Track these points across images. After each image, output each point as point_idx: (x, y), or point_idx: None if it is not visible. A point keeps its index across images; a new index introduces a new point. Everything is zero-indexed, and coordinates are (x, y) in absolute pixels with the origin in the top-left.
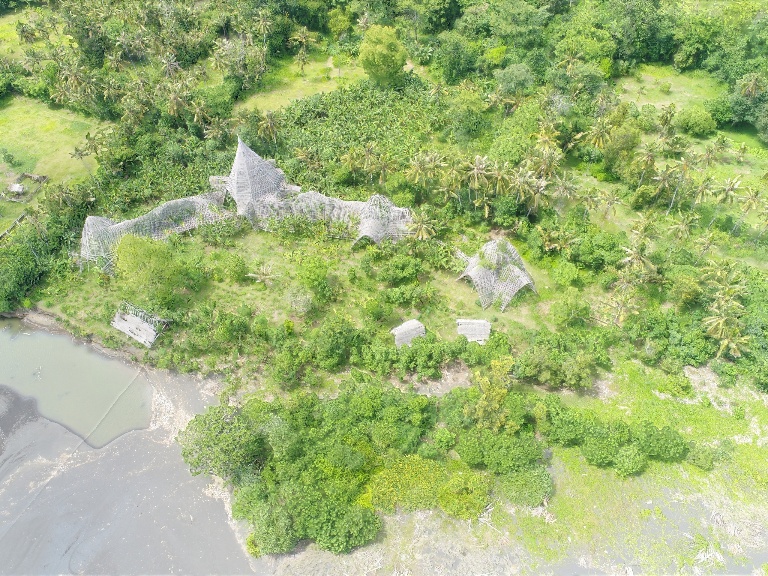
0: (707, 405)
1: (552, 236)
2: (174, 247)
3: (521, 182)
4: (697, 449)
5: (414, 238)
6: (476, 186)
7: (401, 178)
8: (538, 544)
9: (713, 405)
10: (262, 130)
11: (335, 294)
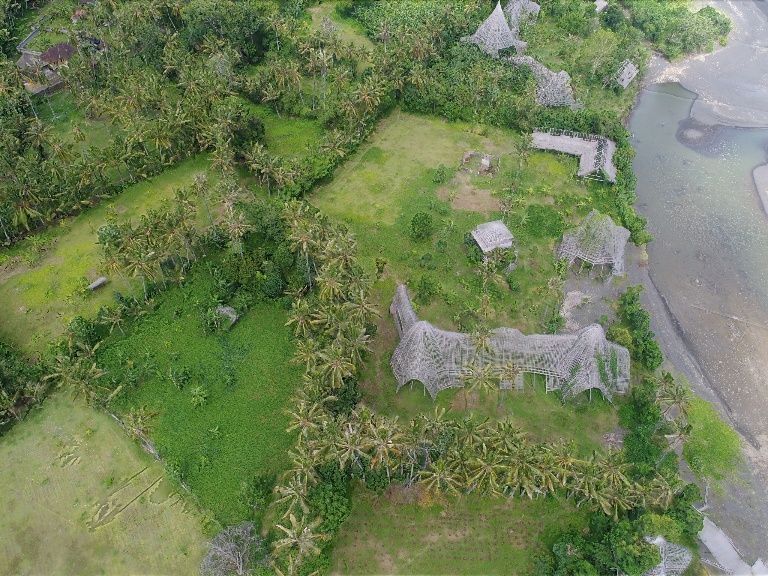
0: None
1: None
2: None
3: None
4: None
5: None
6: None
7: None
8: None
9: None
10: None
11: None
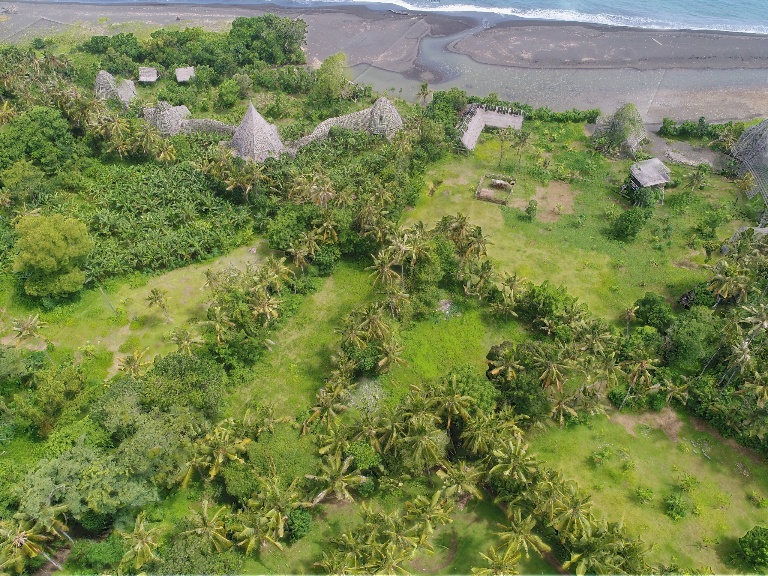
0: None
1: None
2: None
3: None
4: None
5: None
6: None
7: None
8: None
9: None
10: None
11: None
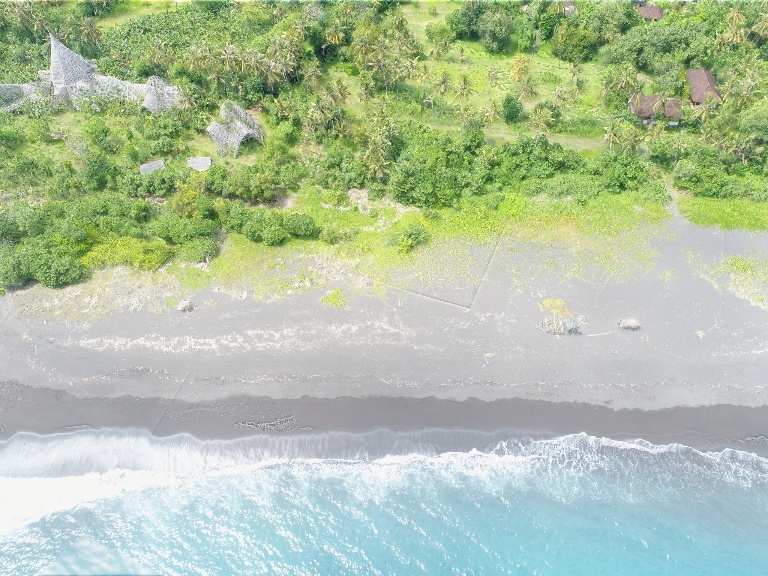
0: (353, 209)
1: (284, 106)
2: (4, 121)
3: (253, 61)
4: (324, 229)
5: (179, 108)
6: (227, 68)
7: (179, 66)
8: (191, 281)
9: (359, 210)
10: (85, 36)
11: (112, 147)
